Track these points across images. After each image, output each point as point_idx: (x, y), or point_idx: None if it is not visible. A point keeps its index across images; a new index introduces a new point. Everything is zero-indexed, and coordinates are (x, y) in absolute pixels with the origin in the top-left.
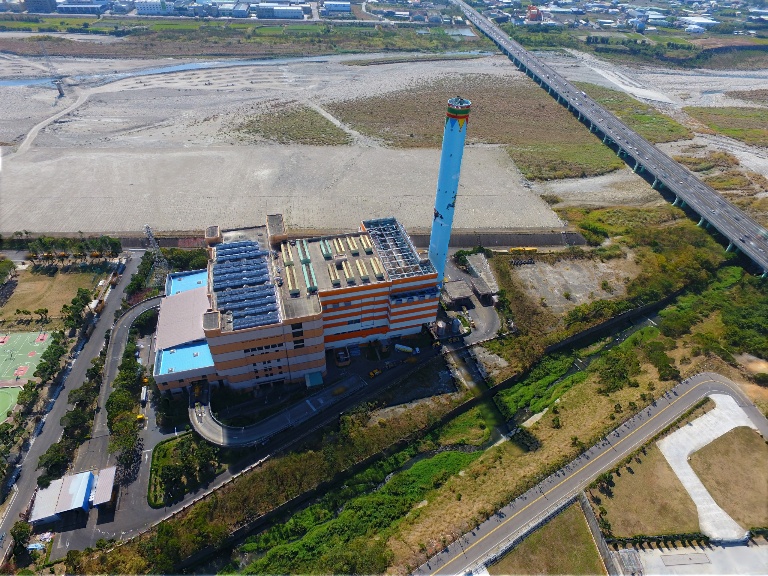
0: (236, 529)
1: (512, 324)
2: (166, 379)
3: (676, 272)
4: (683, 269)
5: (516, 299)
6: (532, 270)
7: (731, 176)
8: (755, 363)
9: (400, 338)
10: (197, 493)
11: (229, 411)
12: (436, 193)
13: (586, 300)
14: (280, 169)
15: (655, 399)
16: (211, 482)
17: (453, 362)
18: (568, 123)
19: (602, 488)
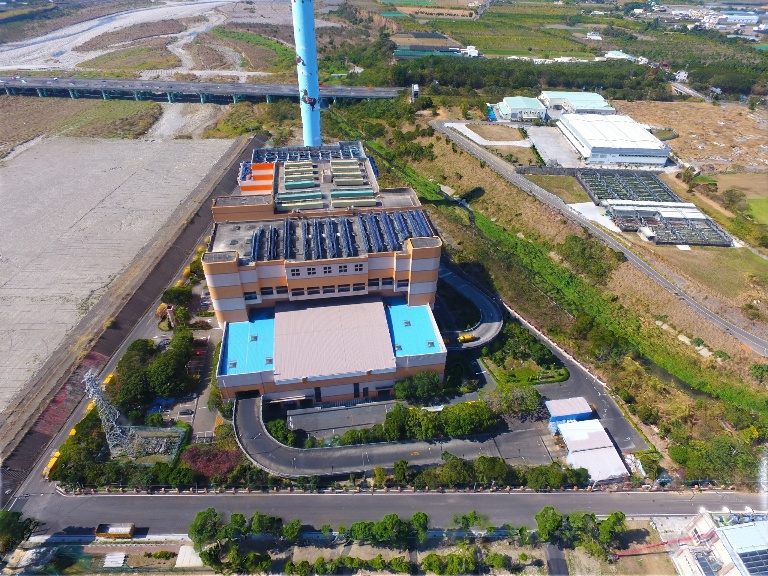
0: (571, 316)
1: None
2: None
3: None
4: None
5: None
6: None
7: (211, 81)
8: None
9: None
10: None
11: None
12: (306, 81)
13: None
14: None
15: None
16: None
17: None
18: (40, 101)
19: (513, 162)
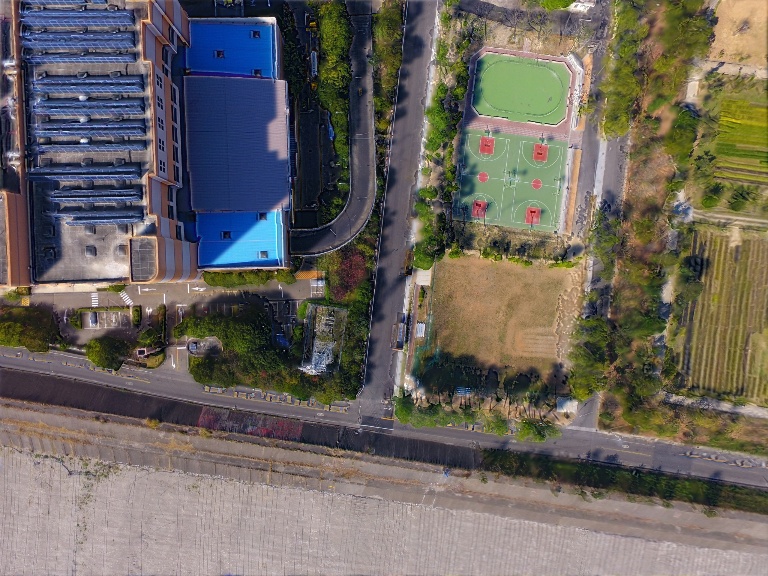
0: None
1: None
2: None
3: None
4: None
5: None
6: None
7: None
8: None
9: None
10: None
11: None
12: None
13: None
14: None
15: None
16: None
17: None
18: None
19: None
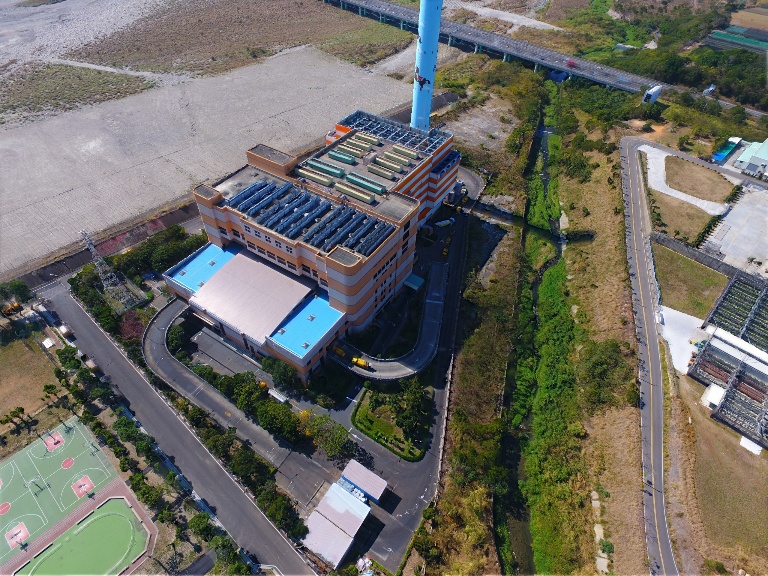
0: (499, 416)
1: (485, 170)
2: (310, 356)
3: (529, 94)
4: (532, 90)
5: (466, 153)
6: (450, 130)
7: (483, 23)
8: (633, 122)
9: (430, 219)
10: (436, 422)
11: (374, 352)
12: (419, 58)
13: (504, 134)
14: (109, 135)
15: (620, 165)
16: (435, 406)
17: (482, 215)
18: (337, 13)
19: None
